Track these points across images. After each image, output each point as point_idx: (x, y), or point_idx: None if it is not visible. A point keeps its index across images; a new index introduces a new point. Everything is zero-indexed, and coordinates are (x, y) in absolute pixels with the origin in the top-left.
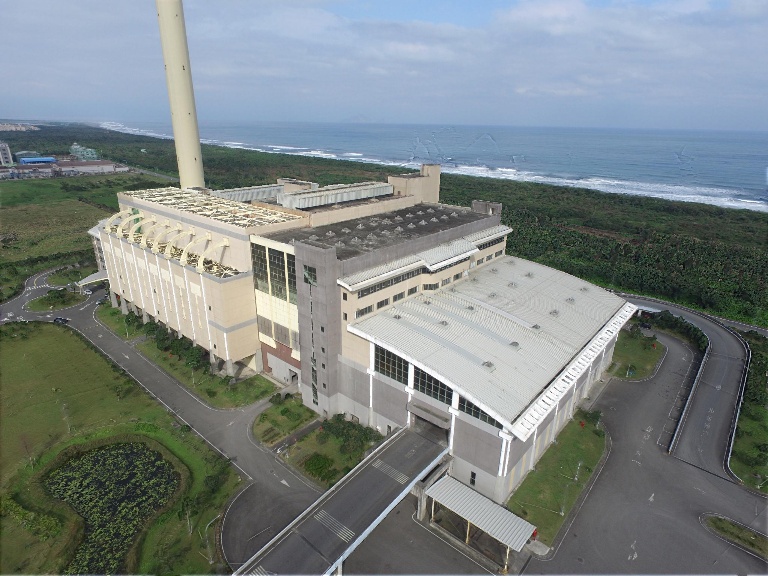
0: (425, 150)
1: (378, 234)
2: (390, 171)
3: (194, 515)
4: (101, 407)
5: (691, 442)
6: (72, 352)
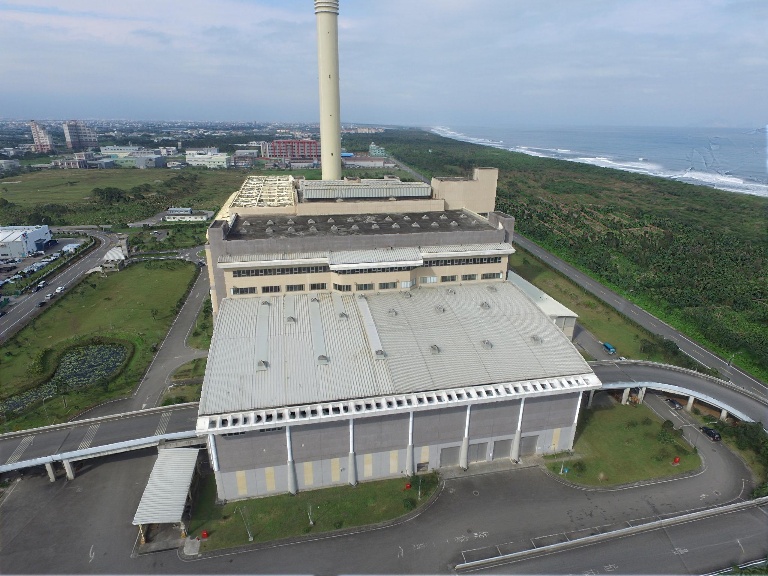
0: (702, 160)
1: (329, 228)
2: (650, 183)
3: (62, 394)
4: (143, 321)
5: None
6: (179, 285)
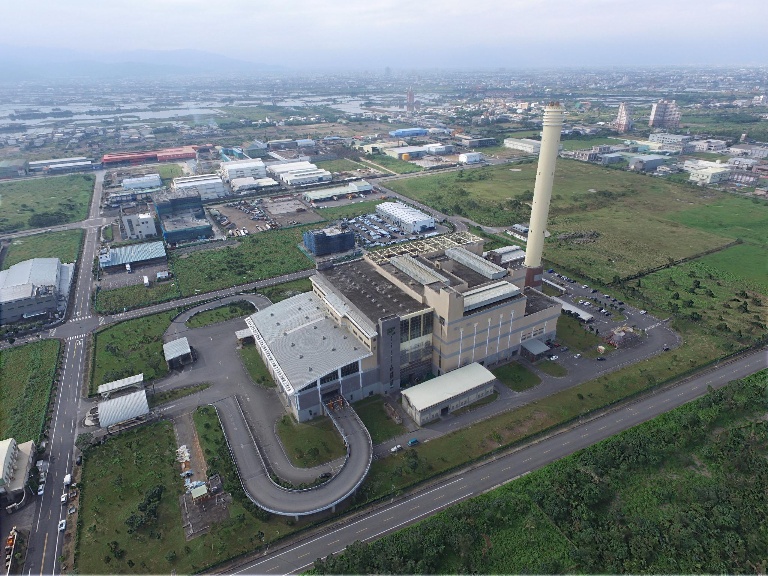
0: None
1: None
2: None
3: None
4: None
5: None
6: None
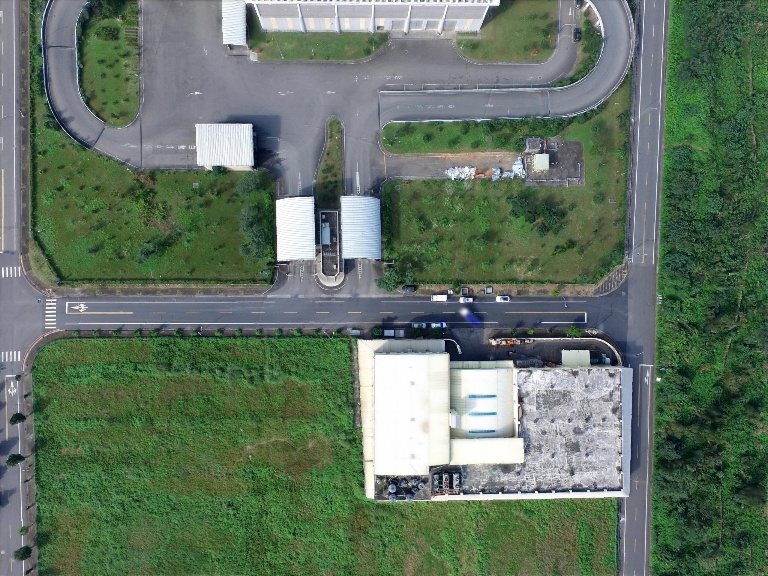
0: None
1: None
2: None
3: None
4: None
5: (403, 101)
6: None
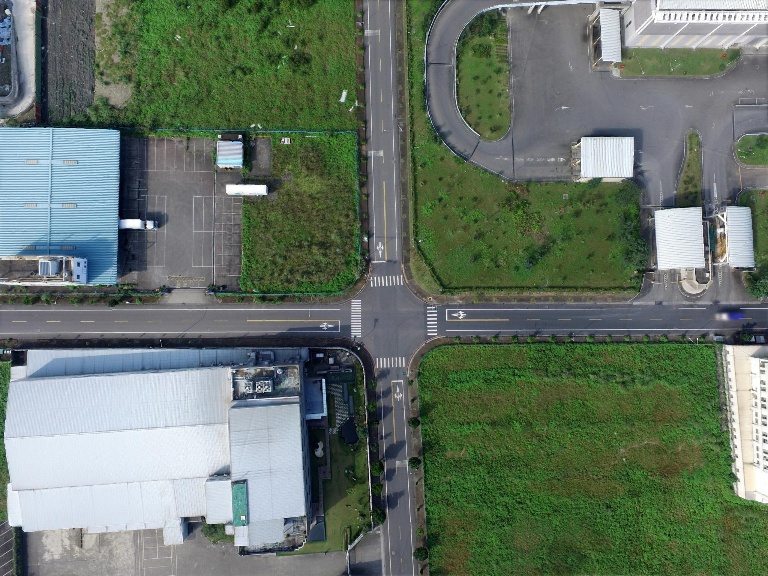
0: None
1: None
2: None
3: None
4: None
5: (756, 115)
6: None
